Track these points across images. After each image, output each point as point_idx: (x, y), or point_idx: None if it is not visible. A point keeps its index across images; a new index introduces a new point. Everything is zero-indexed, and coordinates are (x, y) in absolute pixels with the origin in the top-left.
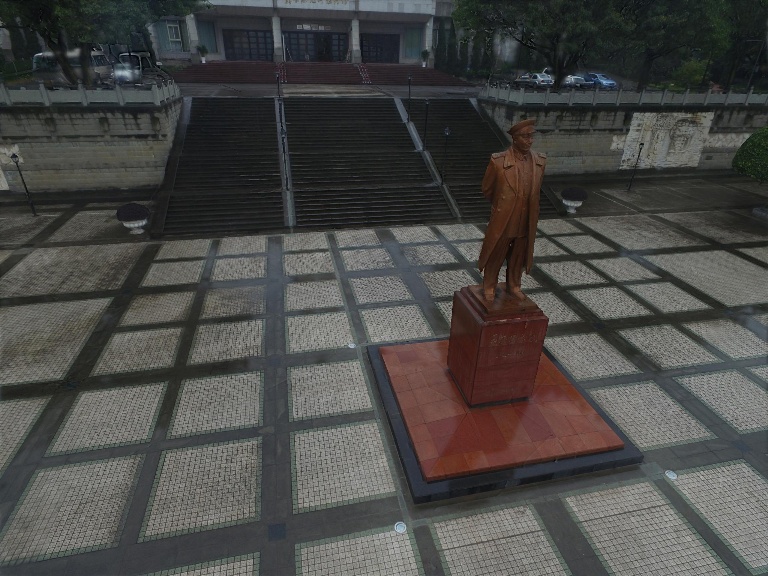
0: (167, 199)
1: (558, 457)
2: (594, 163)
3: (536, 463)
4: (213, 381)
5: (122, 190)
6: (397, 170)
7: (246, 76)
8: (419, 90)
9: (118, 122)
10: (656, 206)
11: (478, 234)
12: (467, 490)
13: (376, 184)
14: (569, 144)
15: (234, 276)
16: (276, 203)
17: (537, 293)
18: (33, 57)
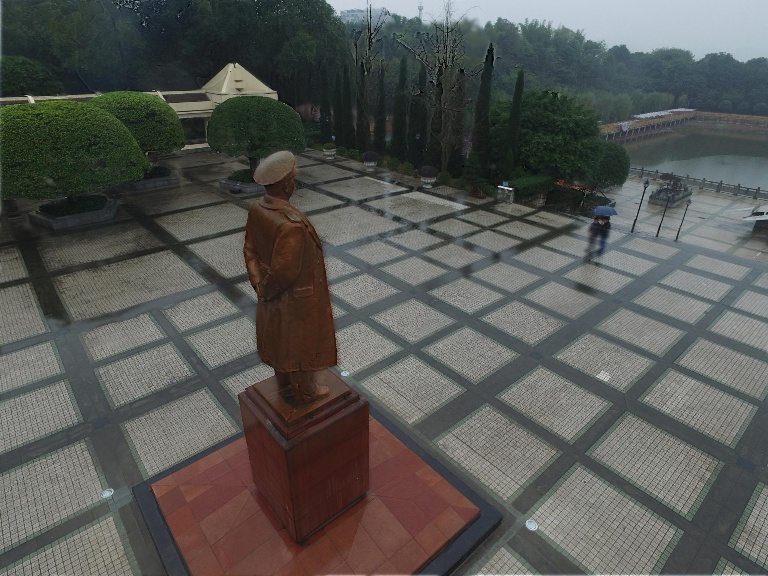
0: None
1: None
2: None
3: None
4: None
5: None
6: None
7: None
8: None
9: None
10: None
11: None
12: None
13: None
14: None
15: None
16: None
17: None
18: None
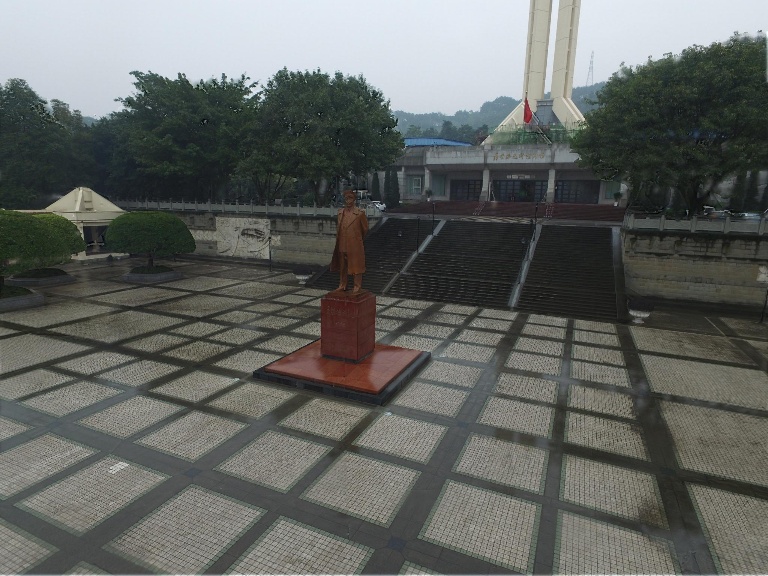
0: (327, 268)
1: (334, 384)
2: (734, 293)
3: (321, 383)
4: (246, 330)
5: (321, 267)
6: (491, 271)
7: (451, 210)
8: (584, 222)
9: (328, 226)
10: (764, 336)
11: (509, 317)
12: (277, 379)
13: (467, 278)
14: (695, 270)
15: (317, 305)
16: (386, 279)
17: (484, 347)
18: (333, 197)
